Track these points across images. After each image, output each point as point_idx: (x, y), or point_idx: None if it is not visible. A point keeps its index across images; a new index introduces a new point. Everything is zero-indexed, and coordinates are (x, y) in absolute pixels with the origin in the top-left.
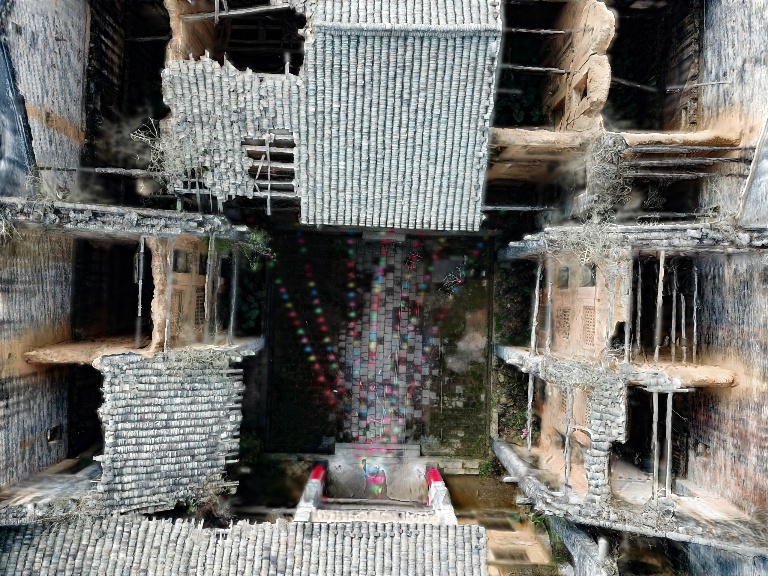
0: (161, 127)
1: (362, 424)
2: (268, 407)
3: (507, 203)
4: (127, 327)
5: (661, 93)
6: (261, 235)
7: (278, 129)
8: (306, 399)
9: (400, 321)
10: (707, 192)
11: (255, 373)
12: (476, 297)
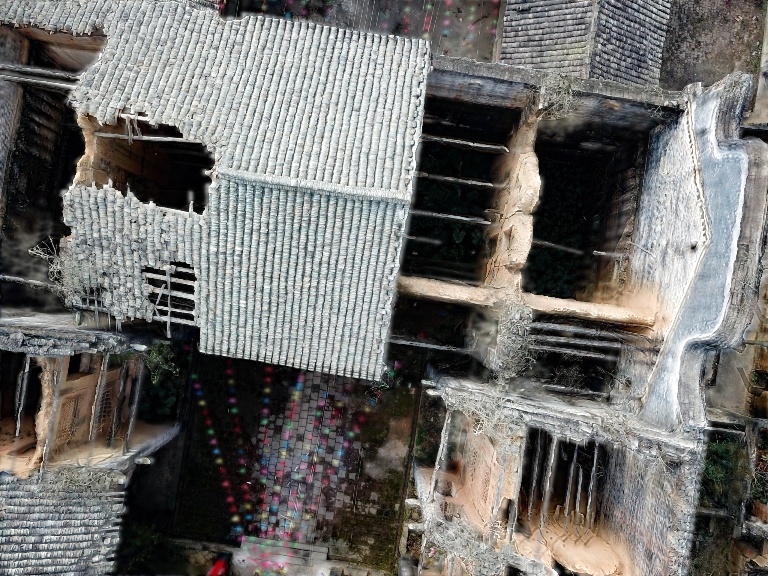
0: (61, 246)
1: (272, 519)
2: (179, 491)
3: (424, 339)
4: (31, 412)
5: (602, 234)
6: (163, 352)
7: (180, 262)
8: (219, 487)
9: (323, 420)
10: (624, 357)
11: (169, 456)
12: (402, 404)
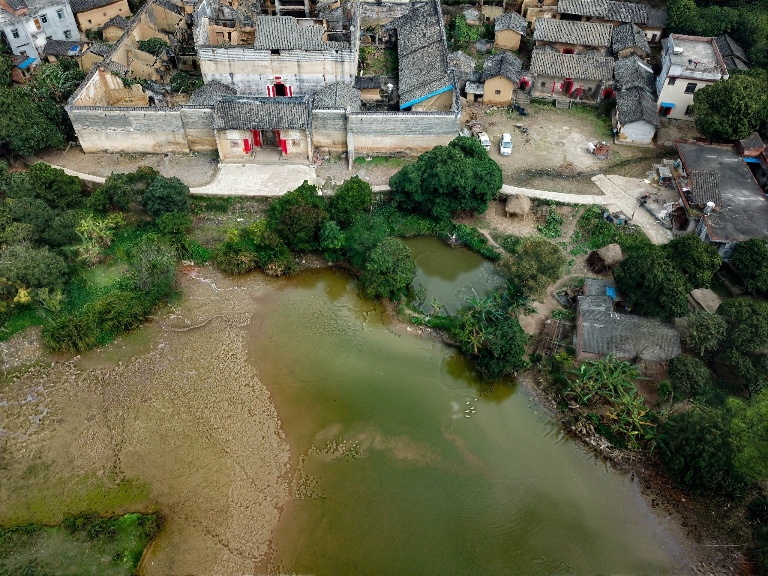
0: None
1: None
2: None
3: None
4: None
5: None
6: None
7: None
8: None
9: None
10: None
11: None
12: None
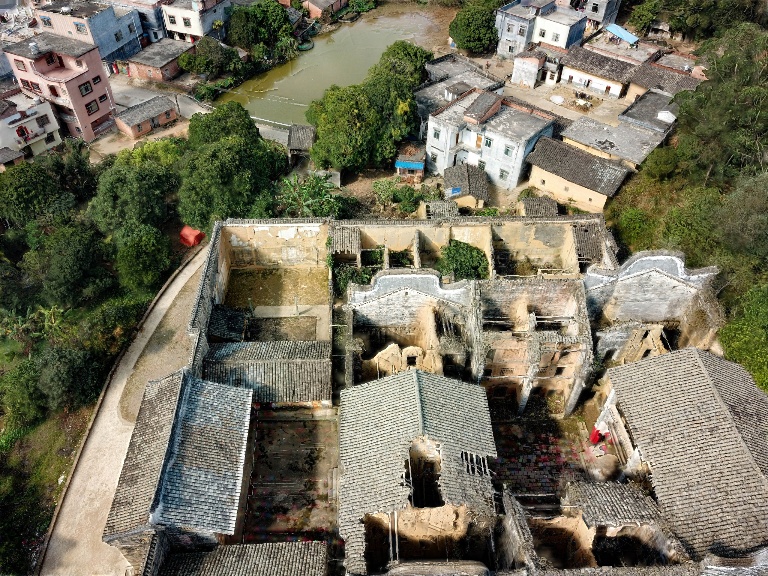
0: None
1: None
2: None
3: None
4: None
5: None
6: None
7: None
8: None
9: (514, 467)
10: None
11: None
12: None
